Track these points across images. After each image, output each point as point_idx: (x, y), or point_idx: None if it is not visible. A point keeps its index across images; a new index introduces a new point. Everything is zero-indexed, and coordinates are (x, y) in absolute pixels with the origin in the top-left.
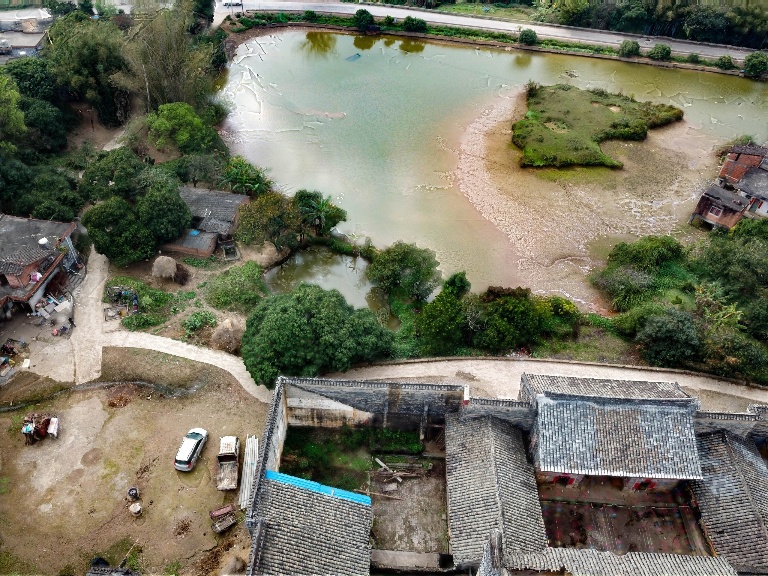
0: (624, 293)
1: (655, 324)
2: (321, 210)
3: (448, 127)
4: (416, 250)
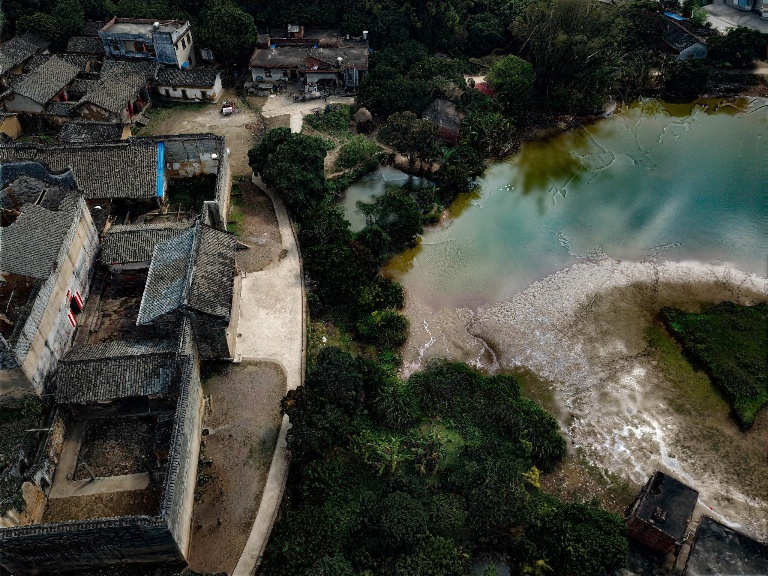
0: (422, 373)
1: None
2: None
3: (710, 250)
4: (402, 204)
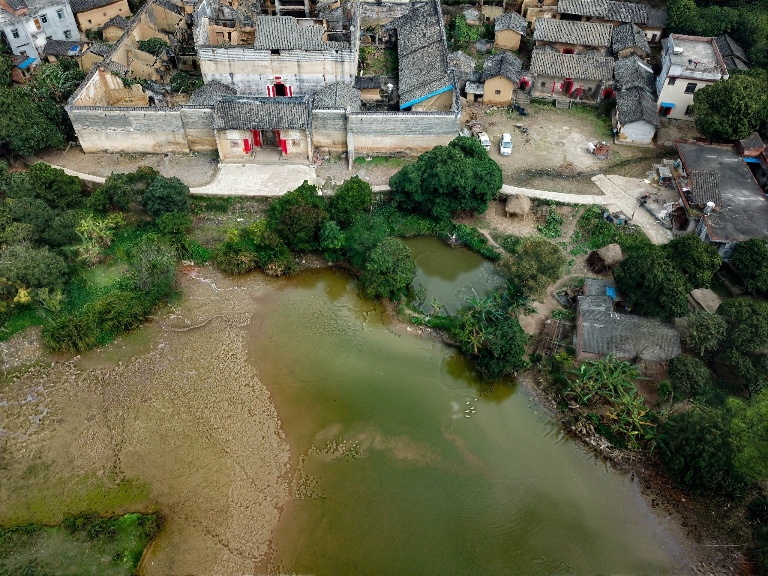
0: None
1: (181, 186)
2: (481, 304)
3: None
4: (371, 248)
